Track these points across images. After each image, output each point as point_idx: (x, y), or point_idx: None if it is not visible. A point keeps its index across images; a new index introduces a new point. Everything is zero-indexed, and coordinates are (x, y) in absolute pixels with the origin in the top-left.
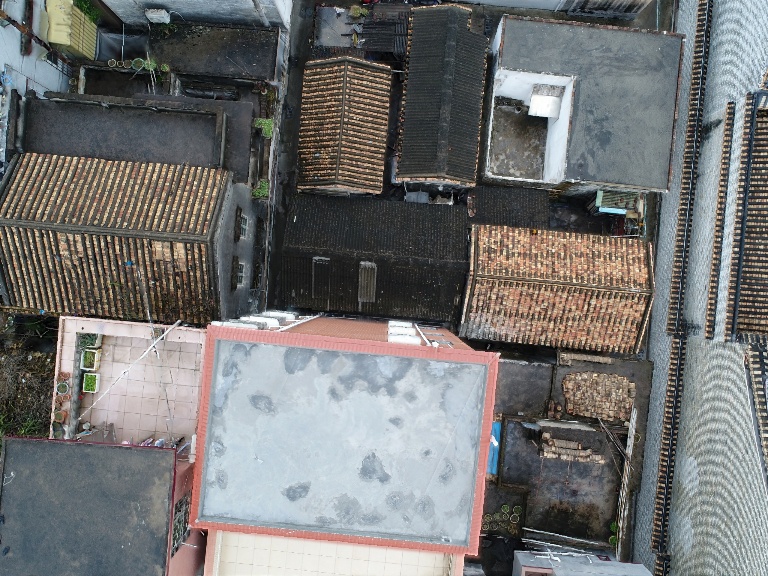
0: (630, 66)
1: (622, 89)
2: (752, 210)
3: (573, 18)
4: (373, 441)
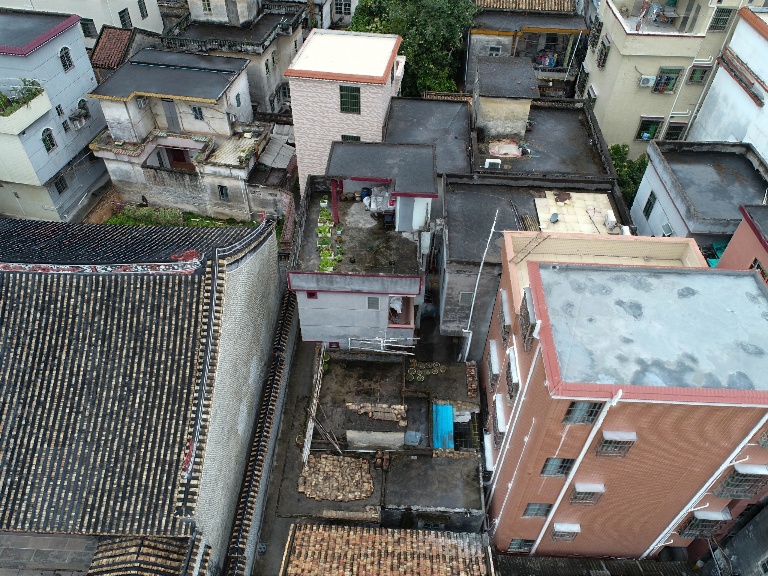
0: None
1: None
2: None
3: None
4: (640, 326)
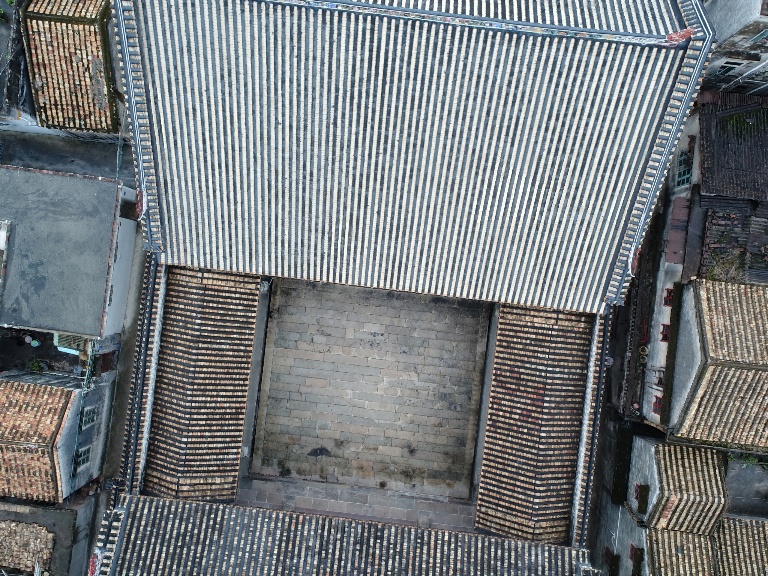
0: (66, 211)
1: (58, 234)
2: (171, 362)
3: (85, 144)
4: None
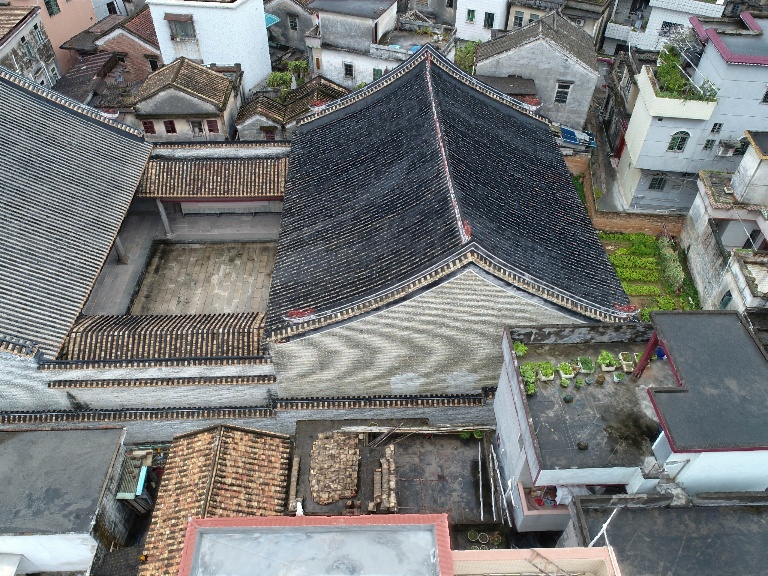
0: None
1: (1, 483)
2: None
3: None
4: None
